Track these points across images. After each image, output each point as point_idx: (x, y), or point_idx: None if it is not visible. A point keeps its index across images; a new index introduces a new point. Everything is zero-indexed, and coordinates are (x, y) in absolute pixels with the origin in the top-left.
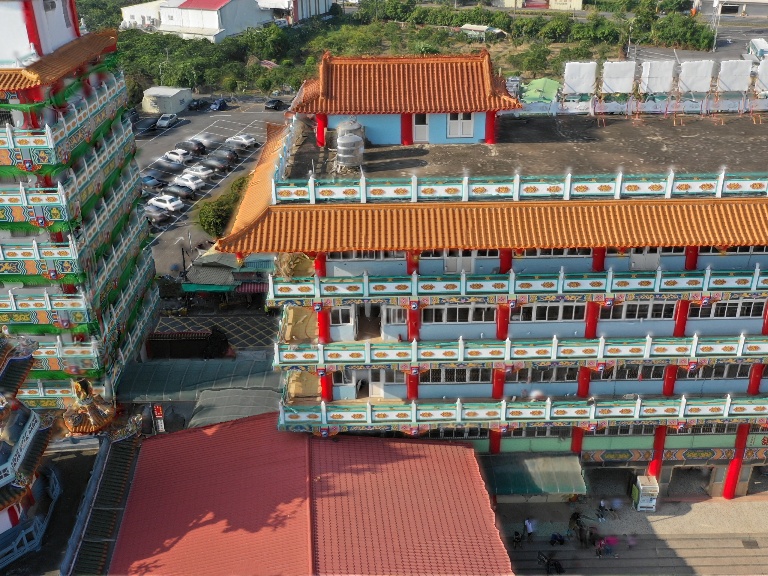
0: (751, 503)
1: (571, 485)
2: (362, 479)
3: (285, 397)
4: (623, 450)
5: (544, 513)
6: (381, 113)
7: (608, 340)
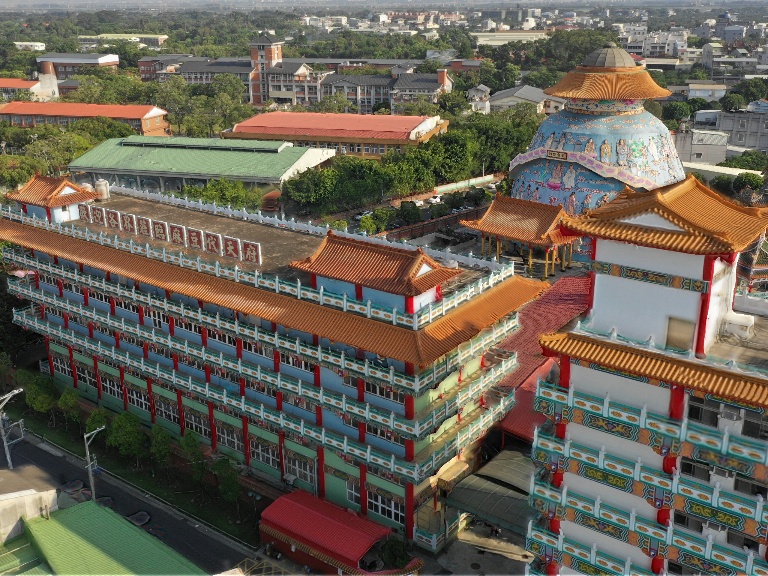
0: None
1: None
2: None
3: (504, 405)
4: None
5: None
6: None
7: None
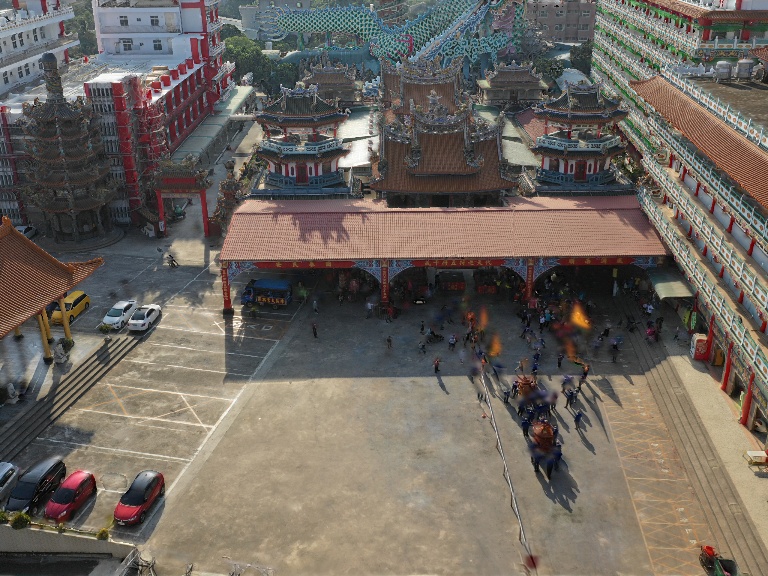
0: (721, 396)
1: (662, 291)
2: (617, 221)
3: (659, 192)
4: (706, 308)
5: (675, 324)
6: (767, 61)
7: (690, 201)
